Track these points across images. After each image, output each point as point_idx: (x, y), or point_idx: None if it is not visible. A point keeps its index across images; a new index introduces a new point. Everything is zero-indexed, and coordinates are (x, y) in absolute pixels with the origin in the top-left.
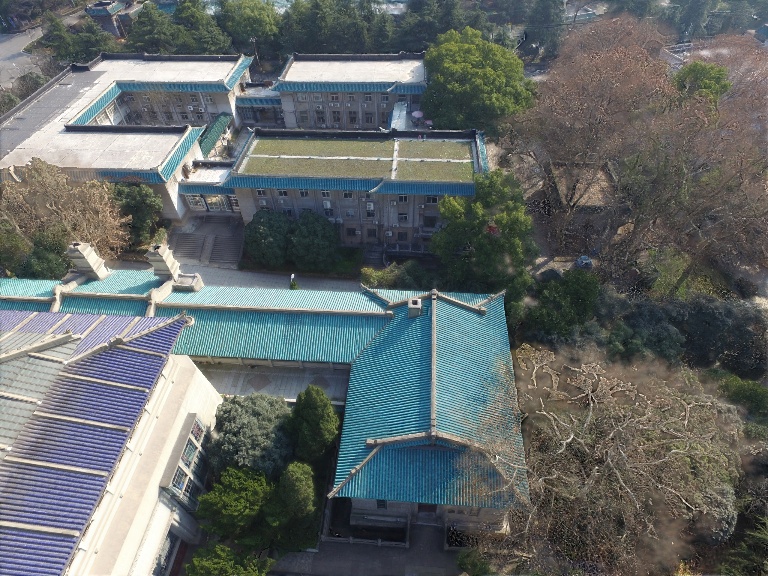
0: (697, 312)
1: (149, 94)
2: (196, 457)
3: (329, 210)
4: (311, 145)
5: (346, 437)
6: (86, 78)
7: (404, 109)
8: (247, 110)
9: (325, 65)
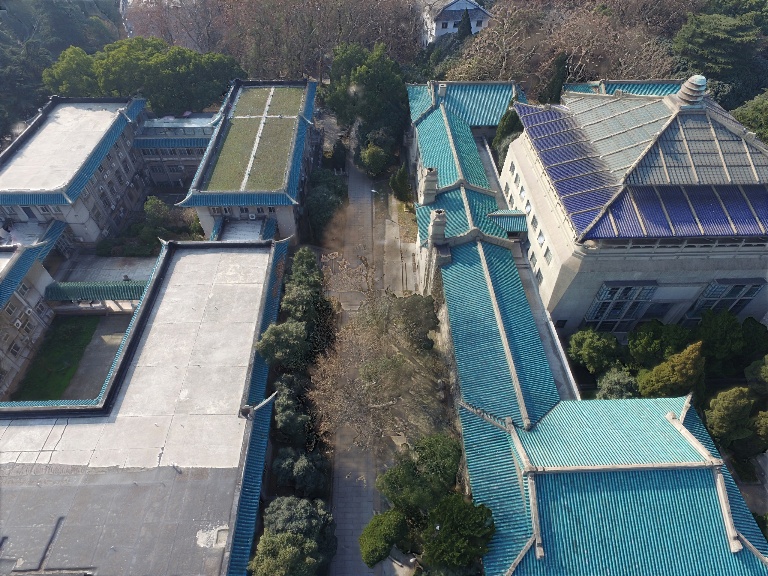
0: None
1: None
2: None
3: None
4: (228, 159)
5: None
6: None
7: (163, 120)
8: None
9: (18, 168)
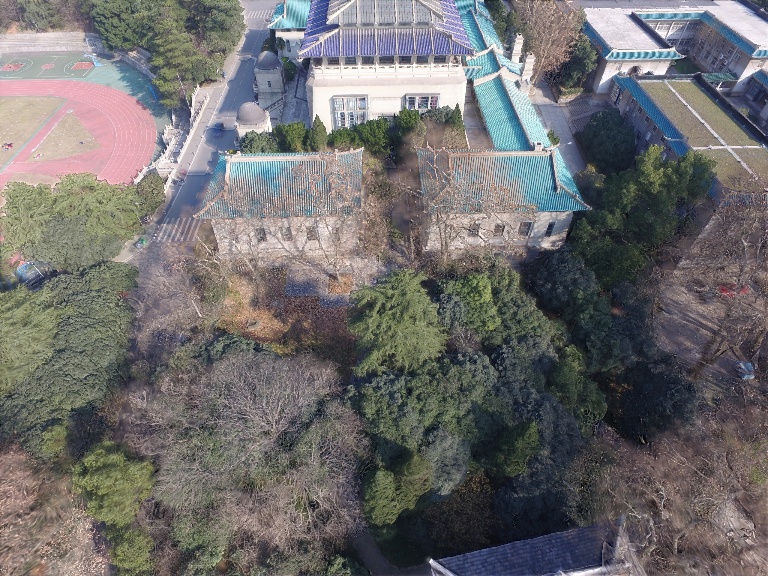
0: (668, 382)
1: (708, 29)
2: (425, 111)
3: (648, 143)
4: (707, 104)
5: (447, 149)
6: (701, 2)
7: None
8: (758, 86)
9: None
